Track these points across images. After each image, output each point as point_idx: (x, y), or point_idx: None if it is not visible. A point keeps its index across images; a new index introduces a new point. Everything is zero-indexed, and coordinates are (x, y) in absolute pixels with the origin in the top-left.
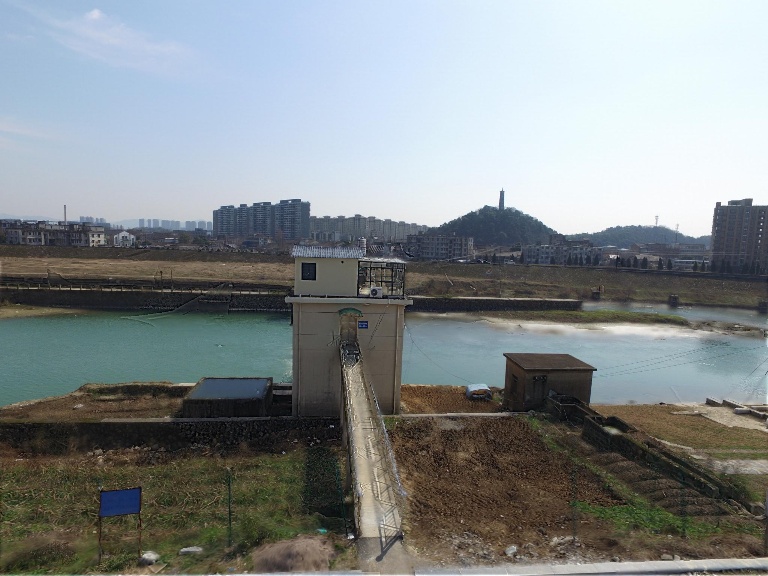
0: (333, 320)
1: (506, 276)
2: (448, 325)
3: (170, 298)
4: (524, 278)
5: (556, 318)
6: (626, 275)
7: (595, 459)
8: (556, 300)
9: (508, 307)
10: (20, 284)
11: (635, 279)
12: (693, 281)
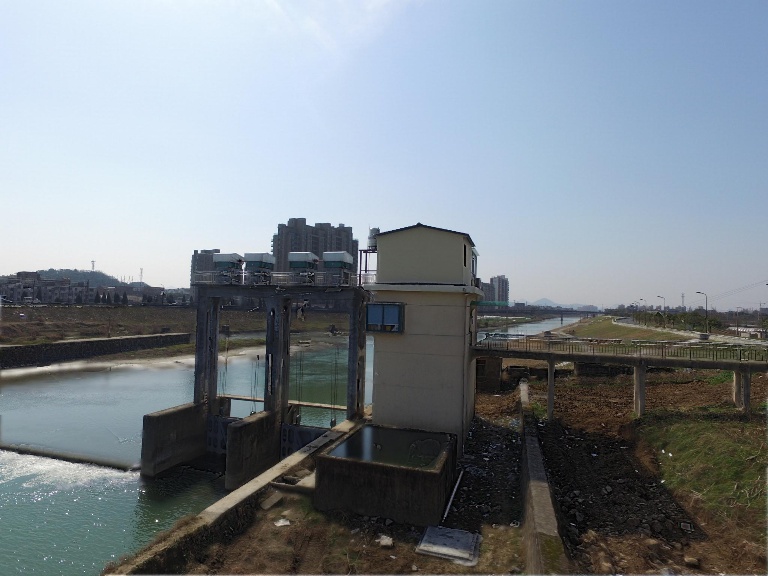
0: (469, 315)
1: (46, 317)
2: (98, 375)
3: None
4: (72, 318)
5: (194, 351)
6: (173, 311)
7: (624, 380)
8: (169, 334)
9: (124, 347)
10: None
11: (183, 314)
12: (226, 313)
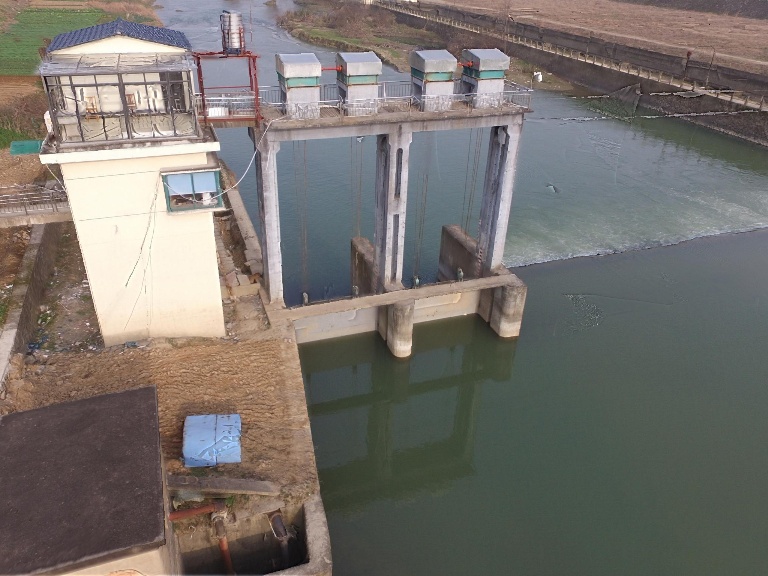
0: None
1: None
2: None
3: (687, 100)
4: None
5: None
6: None
7: None
8: None
9: None
10: (560, 48)
11: None
12: None
